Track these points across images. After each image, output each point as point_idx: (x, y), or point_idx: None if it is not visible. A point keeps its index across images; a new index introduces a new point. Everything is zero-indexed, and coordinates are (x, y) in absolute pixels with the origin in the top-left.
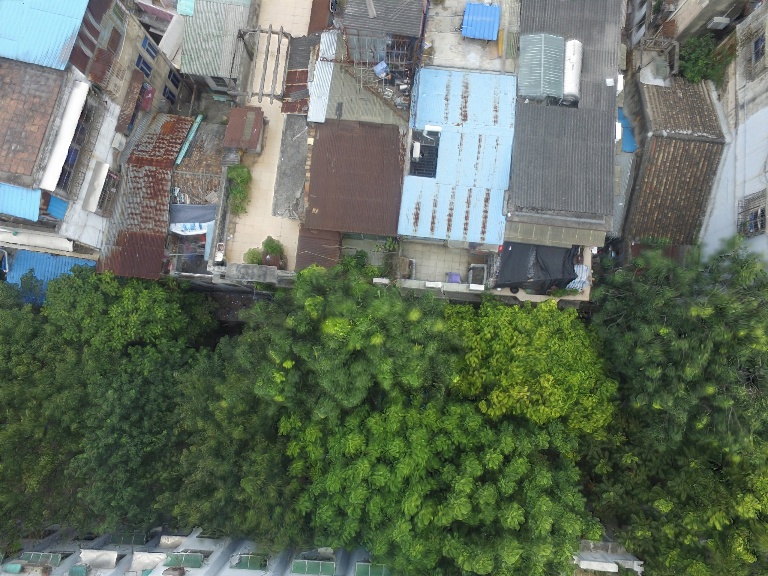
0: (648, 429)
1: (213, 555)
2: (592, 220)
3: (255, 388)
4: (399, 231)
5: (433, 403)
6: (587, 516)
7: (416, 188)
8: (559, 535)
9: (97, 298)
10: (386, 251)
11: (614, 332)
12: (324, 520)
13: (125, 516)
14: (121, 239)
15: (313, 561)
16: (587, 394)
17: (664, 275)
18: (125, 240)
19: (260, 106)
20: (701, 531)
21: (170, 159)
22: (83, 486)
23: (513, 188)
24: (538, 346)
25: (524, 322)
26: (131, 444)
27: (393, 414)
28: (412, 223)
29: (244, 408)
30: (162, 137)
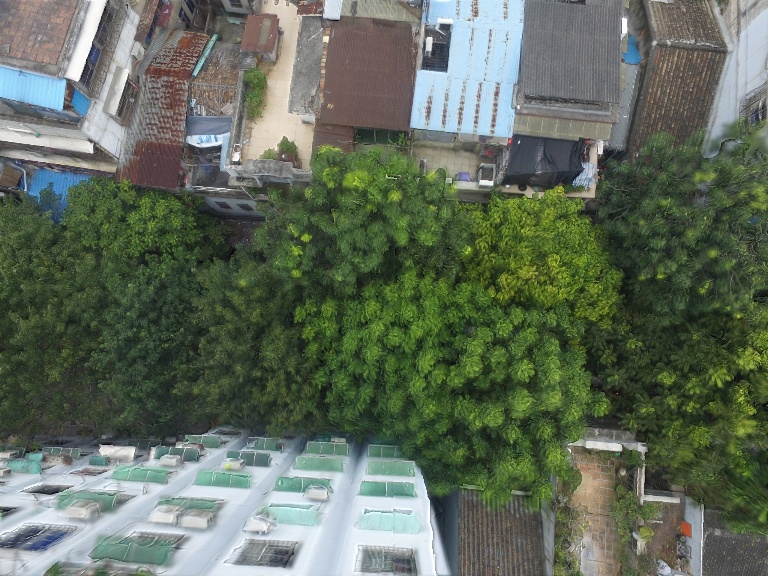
0: (652, 314)
1: (229, 443)
2: (599, 112)
3: (273, 267)
4: (411, 125)
5: (445, 280)
6: (593, 391)
7: (428, 82)
8: (567, 396)
9: (116, 204)
10: (399, 146)
11: (619, 225)
12: (340, 387)
13: (143, 411)
14: (139, 149)
15: (327, 442)
16: (593, 281)
17: (668, 158)
18: (143, 150)
19: (276, 14)
20: (703, 397)
21: (187, 70)
22: (103, 380)
23: (522, 78)
24: (546, 225)
25: (533, 204)
26: (150, 339)
27: (407, 281)
28: (424, 117)
29: (261, 294)
30: (179, 51)
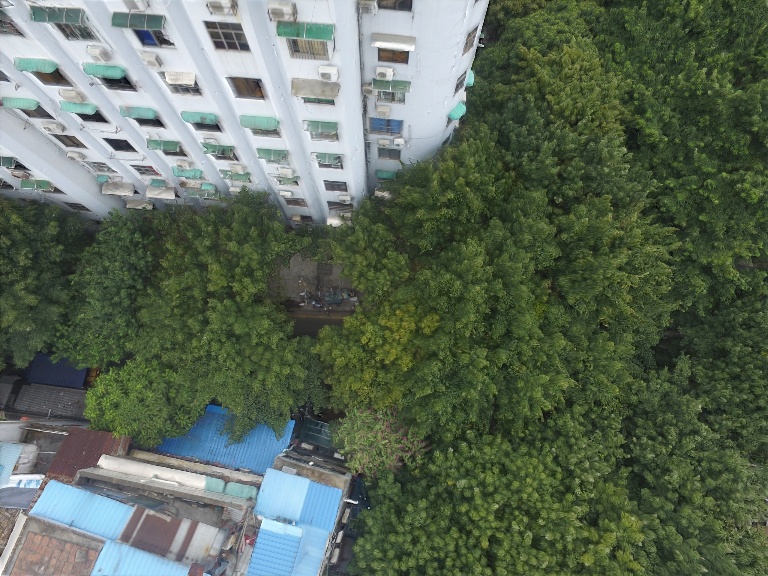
0: None
1: None
2: None
3: None
4: None
5: None
6: None
7: None
8: None
9: None
10: None
11: None
12: None
13: None
14: None
15: None
16: None
17: None
18: None
19: None
20: None
21: None
22: None
23: None
24: None
25: None
26: None
27: None
28: None
29: None
30: None
